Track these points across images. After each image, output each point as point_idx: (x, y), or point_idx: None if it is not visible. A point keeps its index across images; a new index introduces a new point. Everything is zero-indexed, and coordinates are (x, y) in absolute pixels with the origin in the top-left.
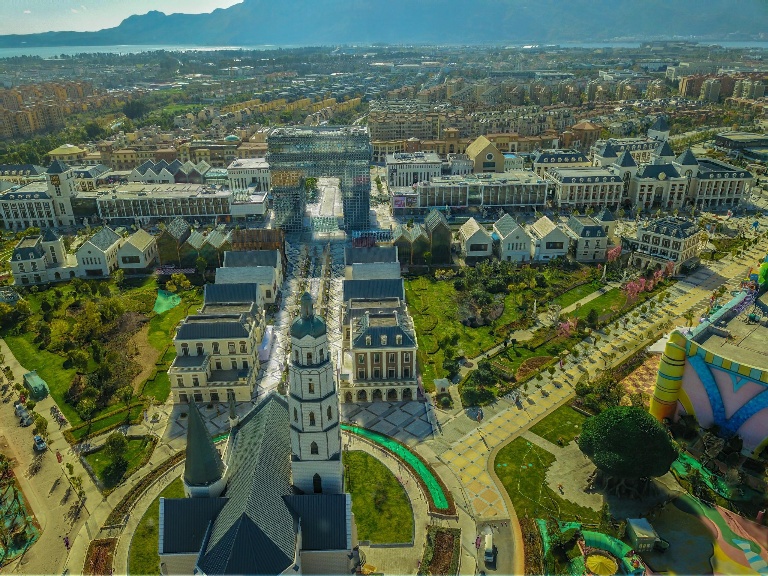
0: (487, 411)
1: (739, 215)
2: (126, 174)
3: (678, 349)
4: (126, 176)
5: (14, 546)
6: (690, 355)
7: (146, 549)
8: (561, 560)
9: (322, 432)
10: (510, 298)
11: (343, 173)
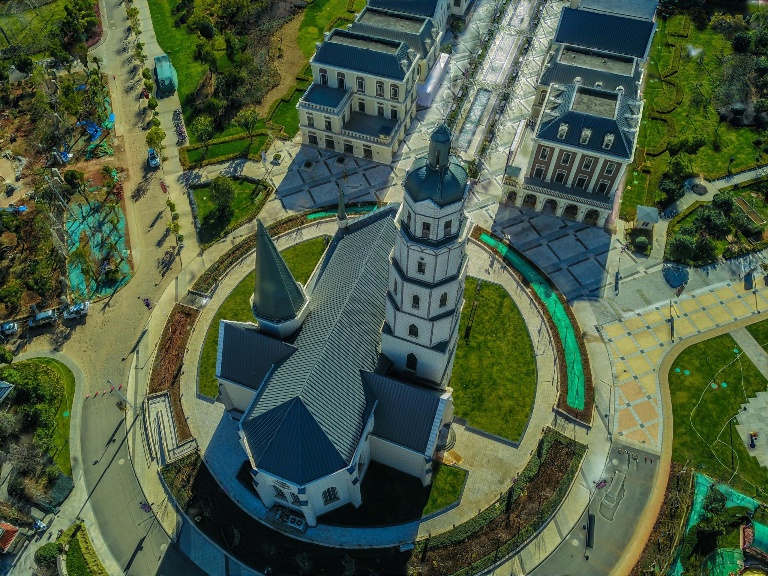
0: (696, 277)
1: None
2: None
3: None
4: None
5: (105, 282)
6: None
7: None
8: (706, 545)
9: (427, 320)
10: None
11: None
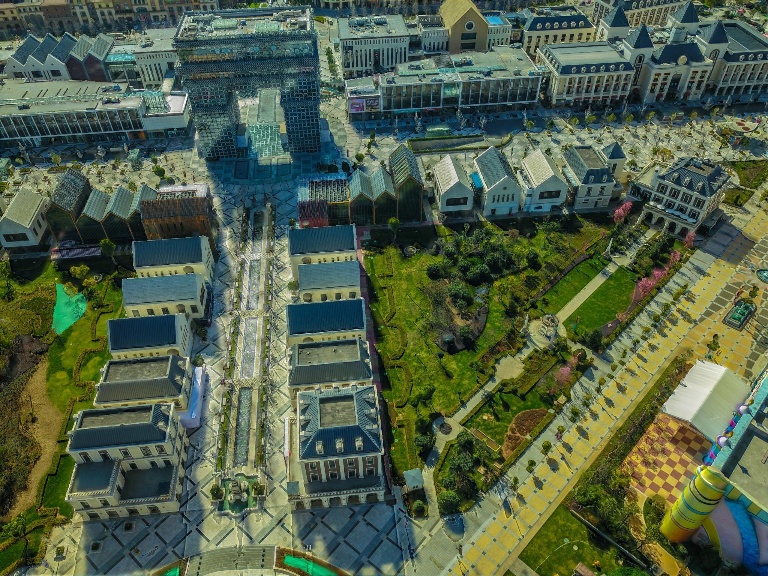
0: (469, 522)
1: (767, 112)
2: (2, 59)
3: (715, 491)
4: (3, 62)
5: None
6: (729, 497)
7: None
8: None
9: None
10: (495, 293)
11: (282, 84)
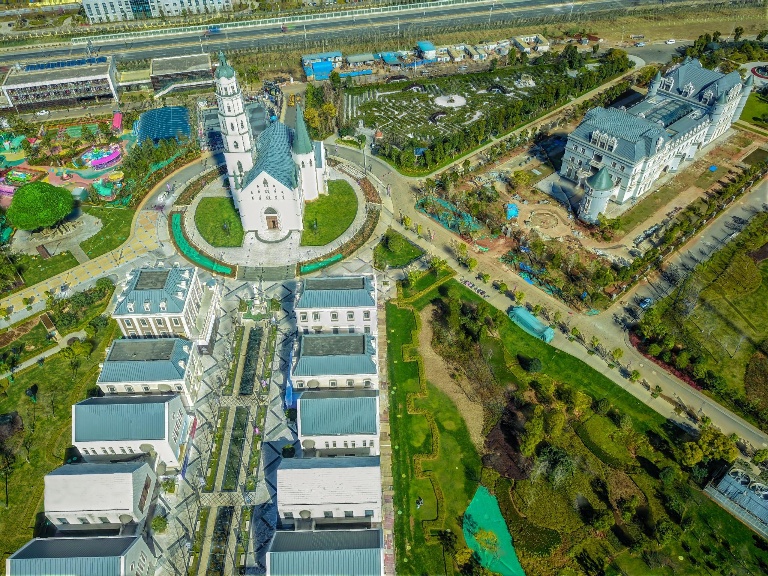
0: None
1: None
2: None
3: None
4: None
5: None
6: None
7: (347, 196)
8: None
9: None
10: None
11: None
